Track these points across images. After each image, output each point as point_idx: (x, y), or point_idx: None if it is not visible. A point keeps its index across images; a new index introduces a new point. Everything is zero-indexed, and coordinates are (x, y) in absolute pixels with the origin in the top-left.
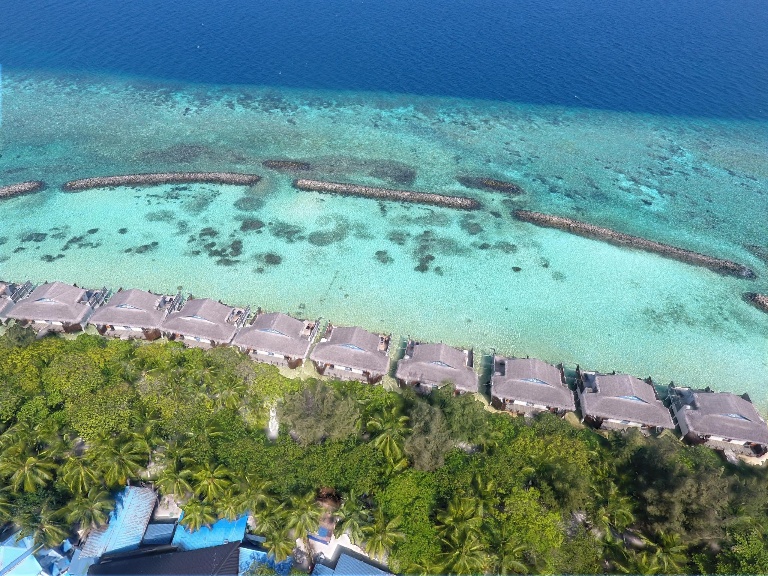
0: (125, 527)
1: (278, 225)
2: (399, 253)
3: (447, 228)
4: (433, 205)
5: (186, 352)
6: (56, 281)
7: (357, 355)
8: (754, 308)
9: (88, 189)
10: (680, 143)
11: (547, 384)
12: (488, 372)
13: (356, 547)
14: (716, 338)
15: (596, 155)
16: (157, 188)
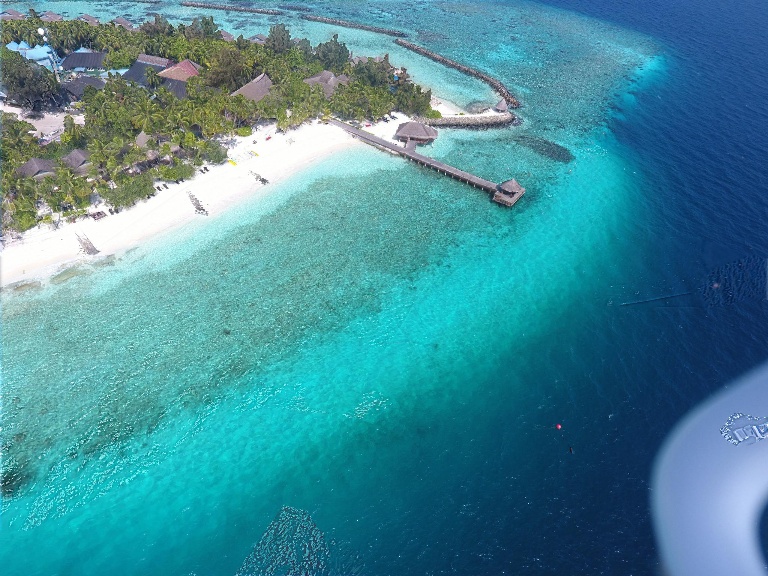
0: None
1: (166, 15)
2: (227, 24)
3: (259, 19)
4: (256, 13)
5: None
6: (48, 11)
7: None
8: (394, 43)
9: (62, 1)
10: (428, 1)
11: (262, 41)
12: None
13: None
14: (365, 48)
15: (370, 2)
16: (101, 2)
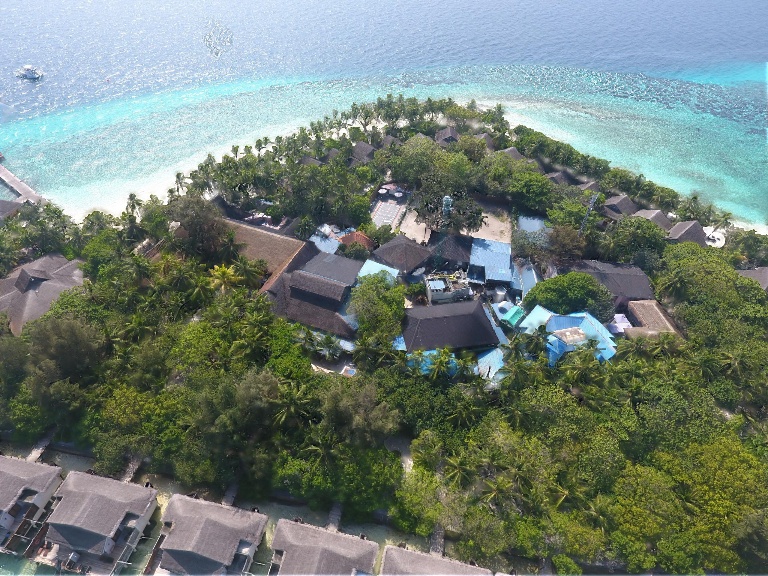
0: (492, 364)
1: None
2: None
3: None
4: None
5: (538, 531)
6: None
7: (315, 543)
8: None
9: None
10: None
11: None
12: (135, 561)
13: (327, 371)
14: None
15: None
16: None
